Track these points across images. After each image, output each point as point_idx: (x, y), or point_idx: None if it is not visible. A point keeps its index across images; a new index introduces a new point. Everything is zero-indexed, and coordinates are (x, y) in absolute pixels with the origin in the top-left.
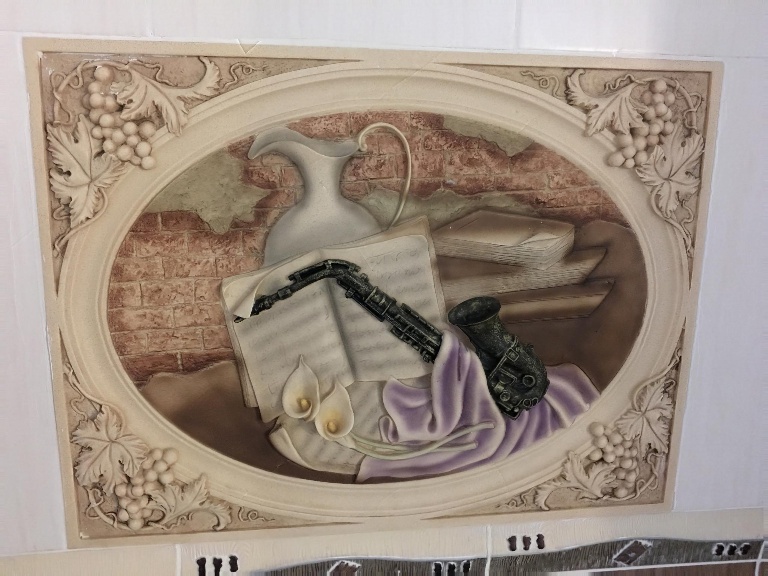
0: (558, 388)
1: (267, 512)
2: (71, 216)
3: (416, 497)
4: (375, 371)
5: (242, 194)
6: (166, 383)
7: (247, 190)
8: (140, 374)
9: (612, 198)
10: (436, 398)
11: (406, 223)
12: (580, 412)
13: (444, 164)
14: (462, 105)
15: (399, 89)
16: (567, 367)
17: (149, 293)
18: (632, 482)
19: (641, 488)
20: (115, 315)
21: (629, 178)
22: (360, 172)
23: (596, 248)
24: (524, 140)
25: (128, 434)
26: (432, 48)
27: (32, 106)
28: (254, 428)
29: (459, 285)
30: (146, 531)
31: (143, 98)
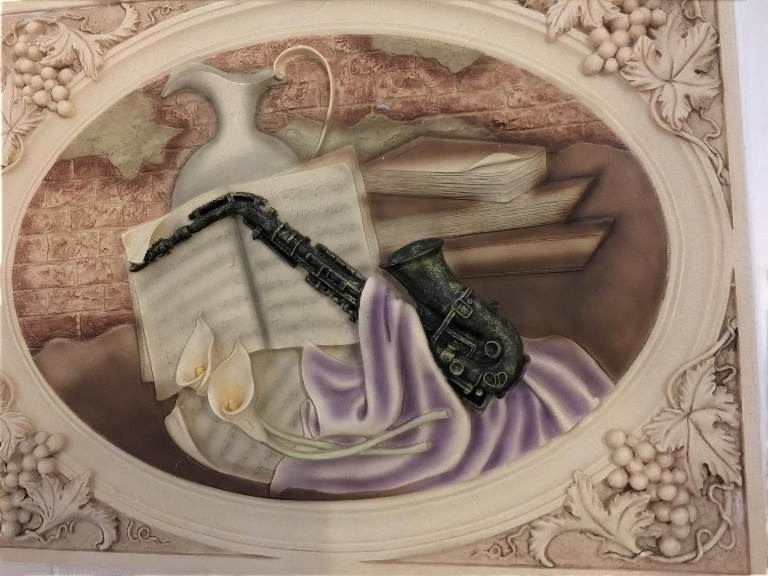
0: (548, 372)
1: (159, 528)
2: None
3: (355, 528)
4: (289, 334)
5: (153, 134)
6: (61, 350)
7: (158, 130)
8: (36, 339)
9: (597, 115)
10: (367, 373)
11: (328, 153)
12: (586, 411)
13: (374, 87)
14: (393, 23)
15: (322, 14)
16: (559, 342)
17: (55, 247)
18: (683, 526)
19: (705, 544)
20: (19, 271)
21: (617, 88)
22: (278, 103)
23: (581, 178)
24: (470, 53)
25: (15, 411)
26: None
27: None
28: (151, 411)
29: (396, 227)
30: (21, 542)
31: (65, 45)
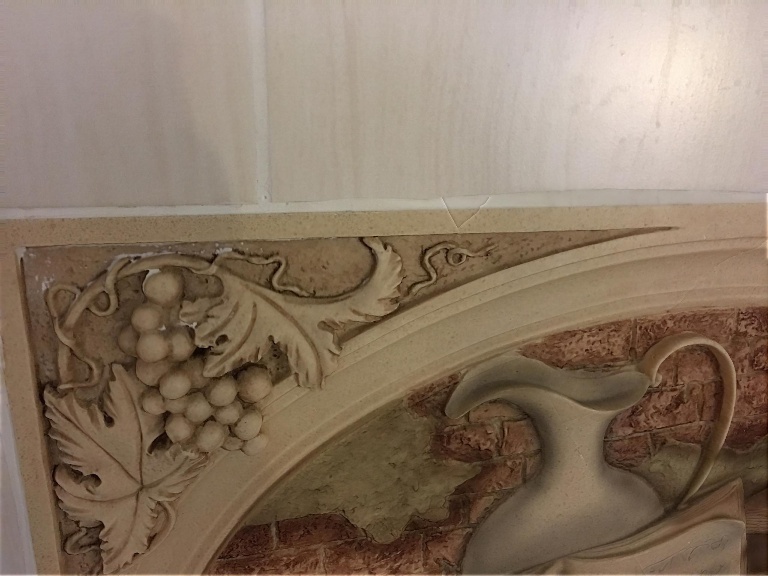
0: None
1: None
2: (103, 554)
3: None
4: None
5: (430, 477)
6: None
7: (439, 469)
8: None
9: None
10: None
11: (710, 497)
12: None
13: None
14: None
15: (725, 269)
16: None
17: None
18: None
19: None
20: None
21: None
22: (641, 419)
23: None
24: None
25: None
26: None
27: (9, 359)
28: None
29: None
30: None
31: (248, 329)
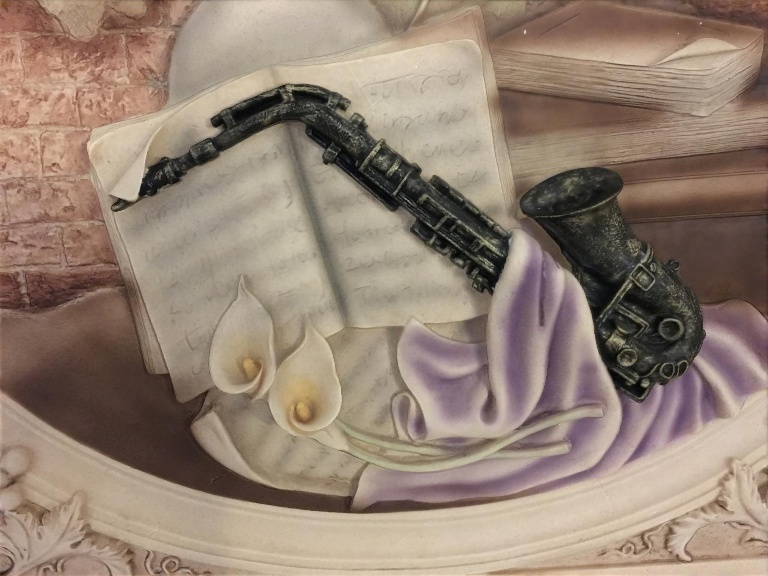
0: (717, 345)
1: (194, 560)
2: None
3: (458, 536)
4: (382, 308)
5: None
6: None
7: None
8: None
9: None
10: (496, 360)
11: (440, 19)
12: (754, 390)
13: None
14: None
15: None
16: (735, 307)
17: None
18: None
19: None
20: None
21: None
22: None
23: None
24: None
25: None
26: None
27: None
28: (165, 412)
29: (541, 146)
30: None
31: None
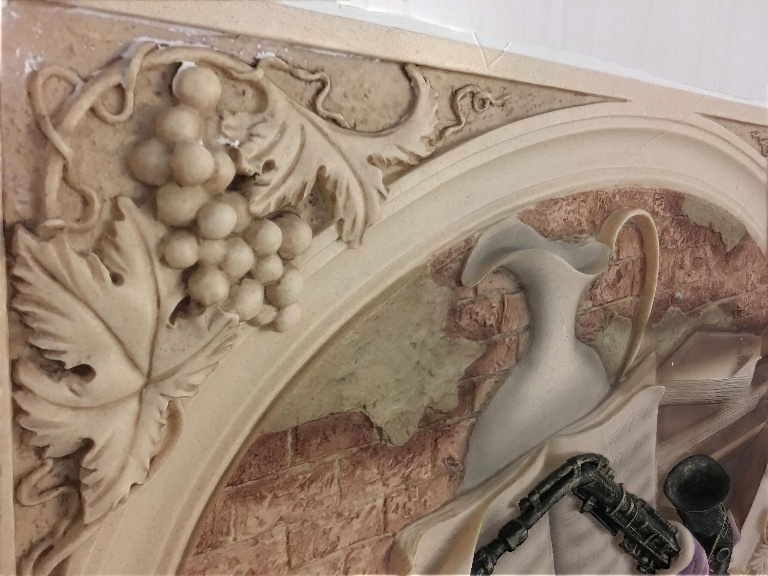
0: None
1: None
2: (87, 491)
3: None
4: None
5: (445, 358)
6: None
7: (453, 348)
8: None
9: None
10: None
11: (640, 368)
12: None
13: (676, 269)
14: (700, 178)
15: (647, 151)
16: None
17: None
18: None
19: None
20: None
21: None
22: (598, 293)
23: (765, 361)
24: (741, 228)
25: None
26: (695, 88)
27: None
28: None
29: (671, 445)
30: None
31: (295, 158)
